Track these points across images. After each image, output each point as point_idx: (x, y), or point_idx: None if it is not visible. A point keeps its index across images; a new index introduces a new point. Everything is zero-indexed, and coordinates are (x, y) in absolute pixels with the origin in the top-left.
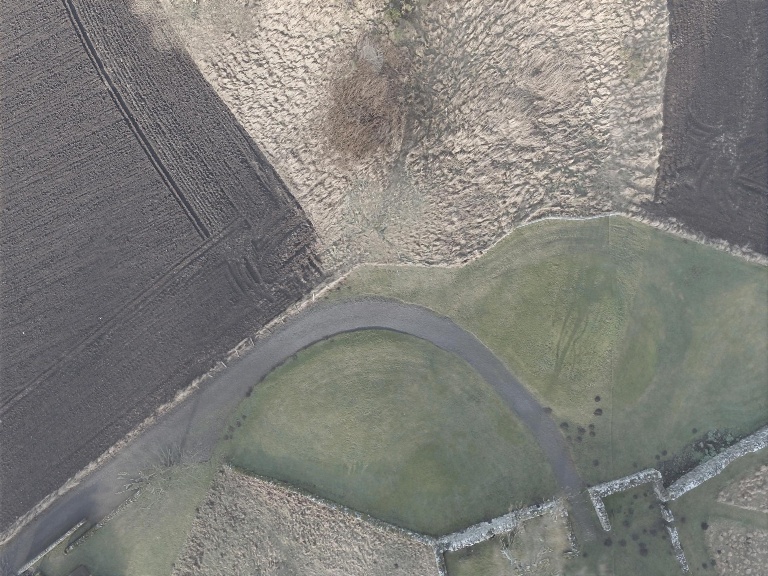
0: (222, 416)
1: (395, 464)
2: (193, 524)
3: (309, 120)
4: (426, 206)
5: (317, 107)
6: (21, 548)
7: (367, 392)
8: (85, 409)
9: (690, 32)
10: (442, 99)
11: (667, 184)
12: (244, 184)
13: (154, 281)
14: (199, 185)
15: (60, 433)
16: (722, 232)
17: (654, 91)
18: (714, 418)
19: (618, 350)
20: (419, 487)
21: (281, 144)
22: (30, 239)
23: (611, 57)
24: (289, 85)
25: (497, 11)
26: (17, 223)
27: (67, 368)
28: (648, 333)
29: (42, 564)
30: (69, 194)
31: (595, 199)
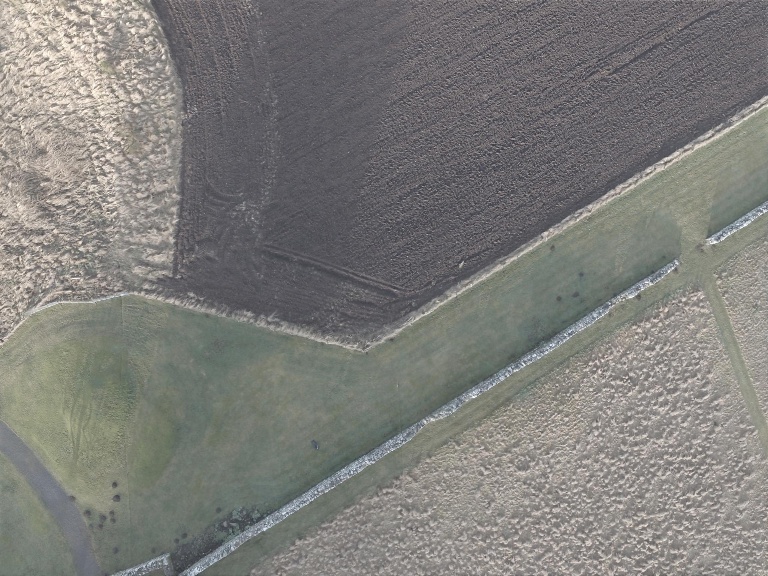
0: None
1: None
2: None
3: None
4: None
5: None
6: None
7: None
8: None
9: (204, 100)
10: None
11: (185, 258)
12: None
13: None
14: None
15: None
16: (248, 303)
17: (163, 164)
18: (241, 495)
19: (131, 434)
20: None
21: None
22: None
23: (112, 133)
24: None
25: None
26: None
27: None
28: (161, 414)
29: None
30: None
31: (105, 280)
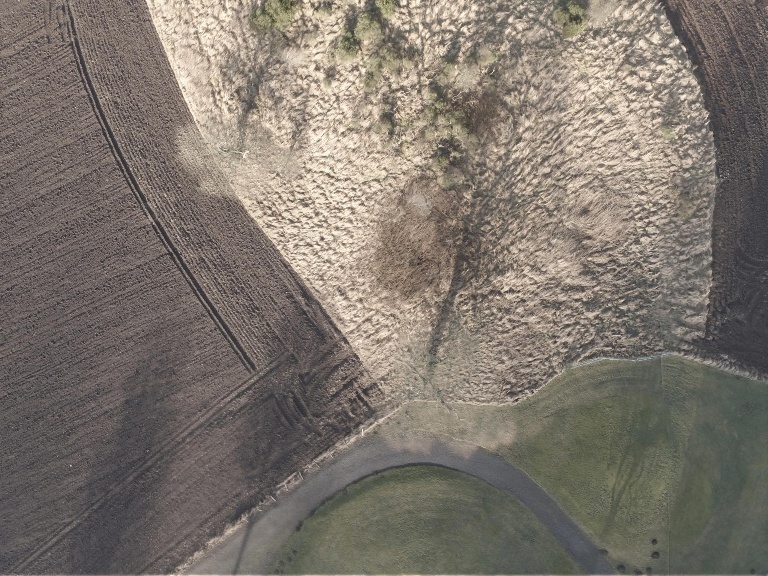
0: (272, 550)
1: None
2: None
3: (356, 259)
4: (476, 345)
5: (364, 247)
6: None
7: (420, 531)
8: (134, 542)
9: (737, 166)
10: (490, 240)
11: (718, 320)
12: (290, 319)
13: (201, 414)
14: (245, 319)
15: (109, 566)
16: None
17: (703, 228)
18: None
19: (674, 493)
20: None
21: (328, 281)
22: (76, 372)
23: (659, 196)
24: (335, 225)
25: (544, 152)
26: (63, 356)
27: (115, 500)
28: (704, 475)
29: None
30: (114, 327)
31: (647, 339)
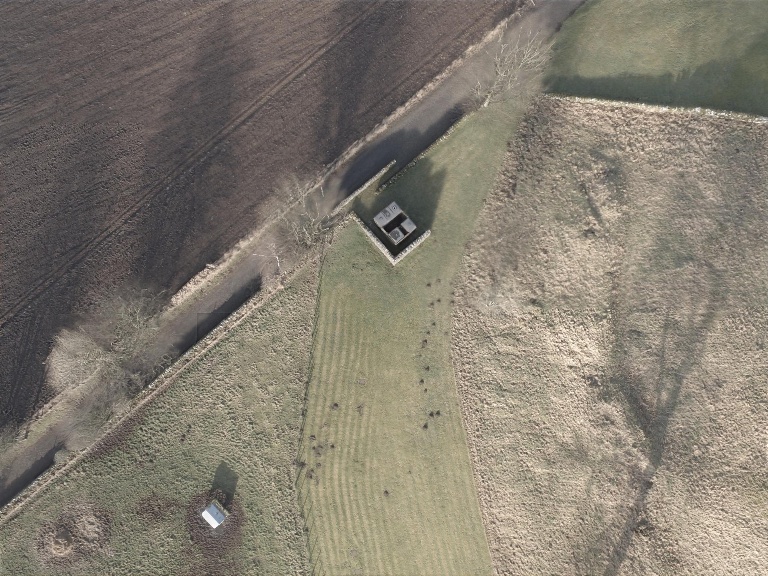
0: None
1: (725, 64)
2: (504, 159)
3: None
4: None
5: None
6: (327, 197)
7: (688, 6)
8: (390, 57)
9: None
10: None
11: None
12: None
13: None
14: None
15: (366, 82)
16: None
17: None
18: None
19: None
20: (754, 78)
21: None
22: None
23: None
24: None
25: None
26: None
27: (371, 20)
28: None
29: (354, 205)
30: None
31: None
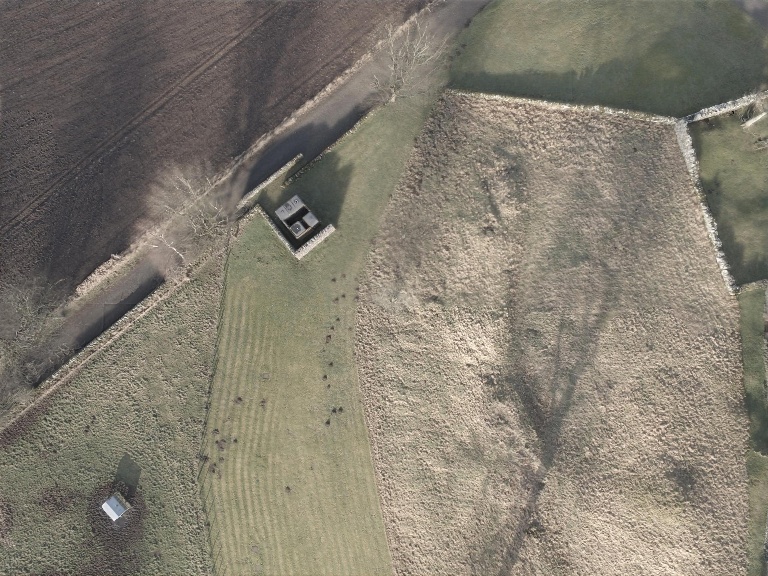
0: None
1: (627, 63)
2: (411, 154)
3: None
4: None
5: None
6: (235, 189)
7: (594, 4)
8: (301, 51)
9: None
10: None
11: None
12: None
13: None
14: None
15: (276, 75)
16: None
17: None
18: None
19: None
20: (655, 77)
21: None
22: None
23: None
24: None
25: None
26: None
27: (282, 13)
28: None
29: (260, 198)
30: None
31: None
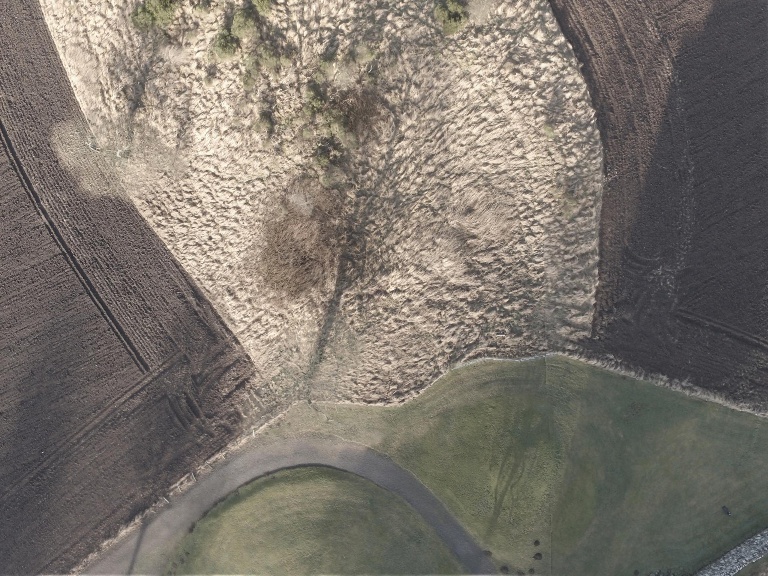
0: (166, 552)
1: None
2: None
3: (243, 259)
4: (362, 345)
5: (251, 247)
6: None
7: (307, 533)
8: (29, 544)
9: (625, 164)
10: (375, 239)
11: (604, 320)
12: (182, 319)
13: (95, 415)
14: (138, 320)
15: (5, 568)
16: (662, 366)
17: (589, 227)
18: (656, 558)
19: (556, 494)
20: None
21: (217, 281)
22: None
23: (544, 195)
24: (222, 224)
25: (428, 151)
26: None
27: (11, 502)
28: (587, 475)
29: None
30: (9, 328)
31: (531, 339)
